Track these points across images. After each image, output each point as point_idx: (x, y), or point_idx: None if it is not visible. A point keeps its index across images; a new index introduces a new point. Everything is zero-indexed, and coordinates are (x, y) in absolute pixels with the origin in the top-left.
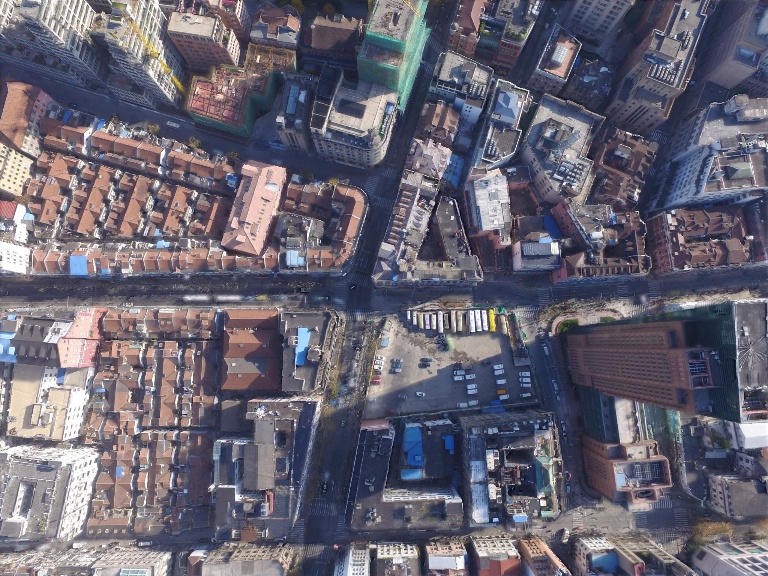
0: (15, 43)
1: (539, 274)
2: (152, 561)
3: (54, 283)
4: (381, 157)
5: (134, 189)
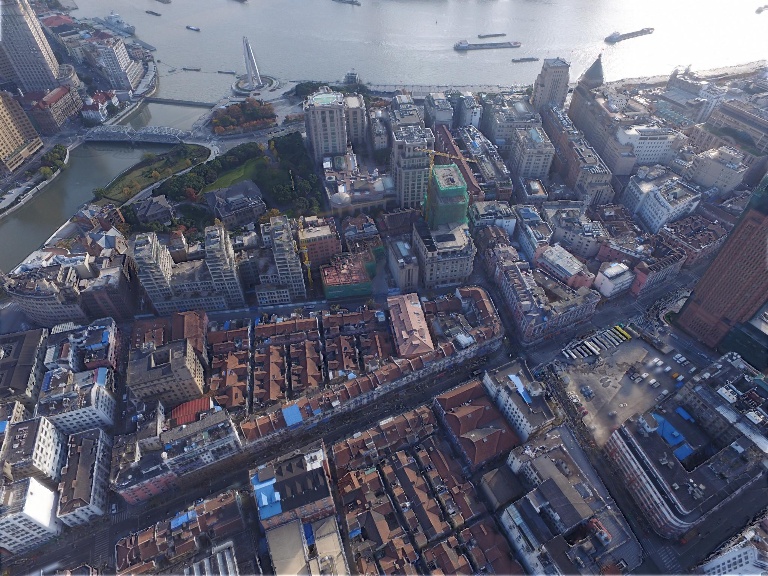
0: (174, 292)
1: (622, 296)
2: None
3: None
4: (472, 268)
5: (306, 351)
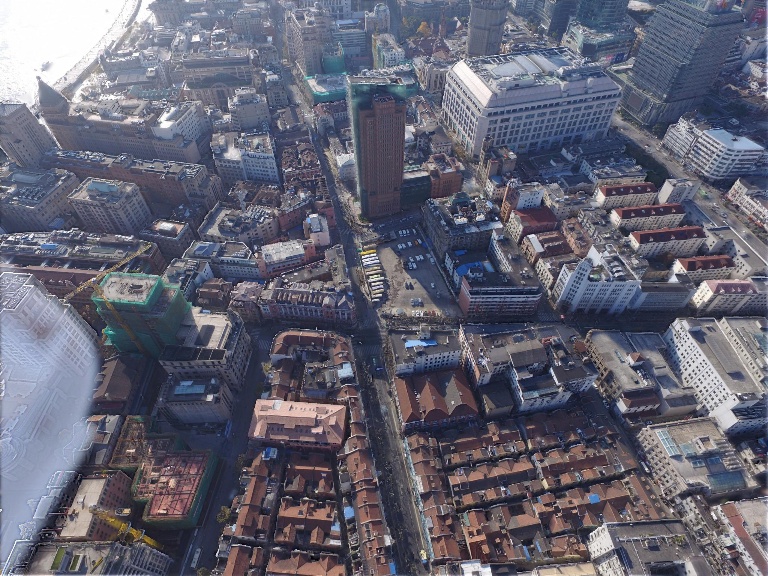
0: None
1: None
2: (648, 434)
3: None
4: None
5: (285, 573)
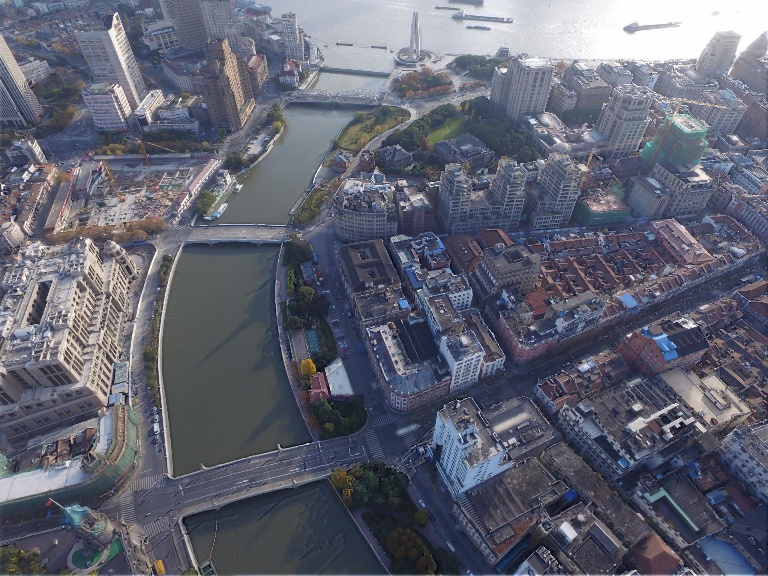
0: (468, 215)
1: None
2: None
3: (598, 337)
4: (706, 202)
5: (601, 260)
